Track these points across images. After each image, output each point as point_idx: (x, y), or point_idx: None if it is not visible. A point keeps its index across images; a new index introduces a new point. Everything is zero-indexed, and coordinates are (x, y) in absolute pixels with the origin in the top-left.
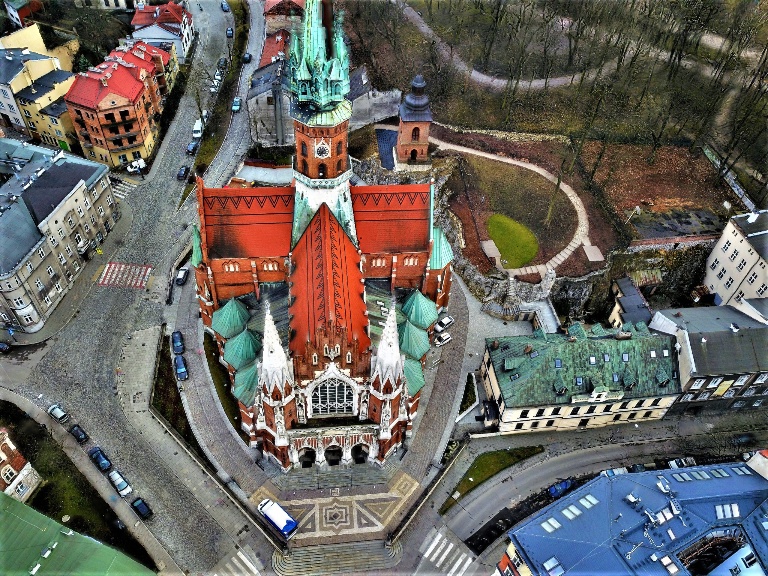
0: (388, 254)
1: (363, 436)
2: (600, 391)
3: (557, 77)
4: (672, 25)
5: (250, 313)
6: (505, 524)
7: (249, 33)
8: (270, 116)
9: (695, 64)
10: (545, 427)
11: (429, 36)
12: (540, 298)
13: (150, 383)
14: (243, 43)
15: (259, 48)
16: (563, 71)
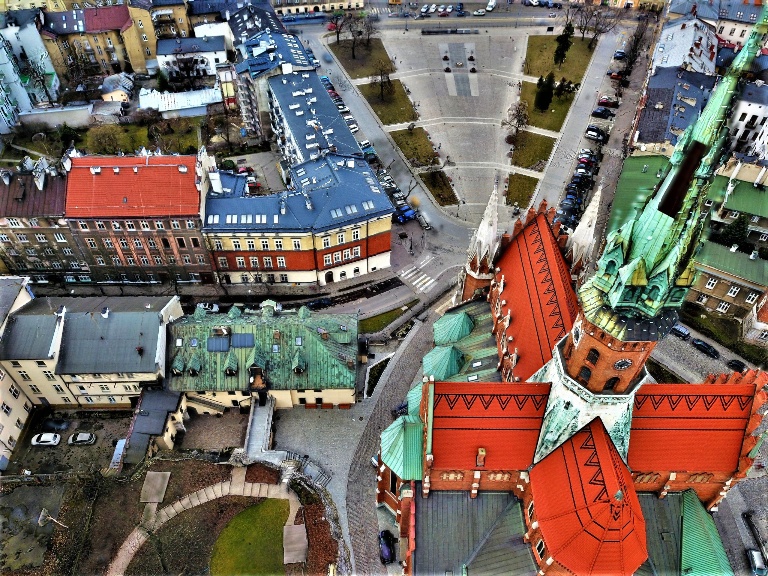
0: None
1: None
2: (272, 301)
3: None
4: None
5: None
6: (372, 288)
7: None
8: None
9: None
10: None
11: None
12: None
13: None
14: None
15: None
16: None
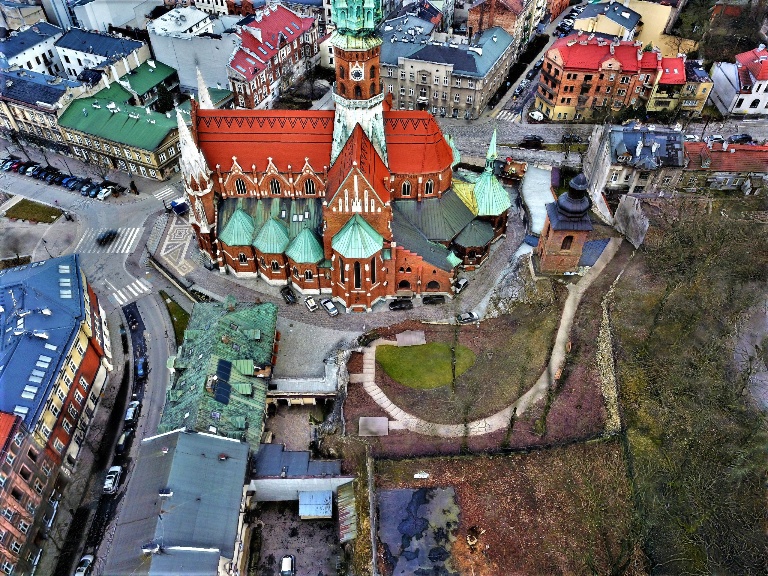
0: None
1: None
2: None
3: None
4: None
5: None
6: None
7: None
8: None
9: None
10: None
11: None
12: None
13: None
14: None
15: None
16: None
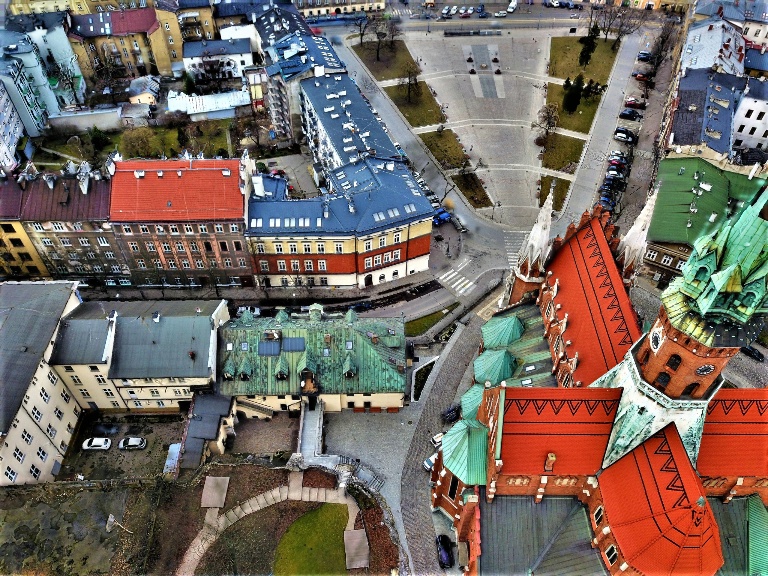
0: None
1: None
2: (319, 305)
3: None
4: None
5: None
6: (411, 291)
7: None
8: None
9: None
10: None
11: None
12: None
13: None
14: None
15: None
16: None
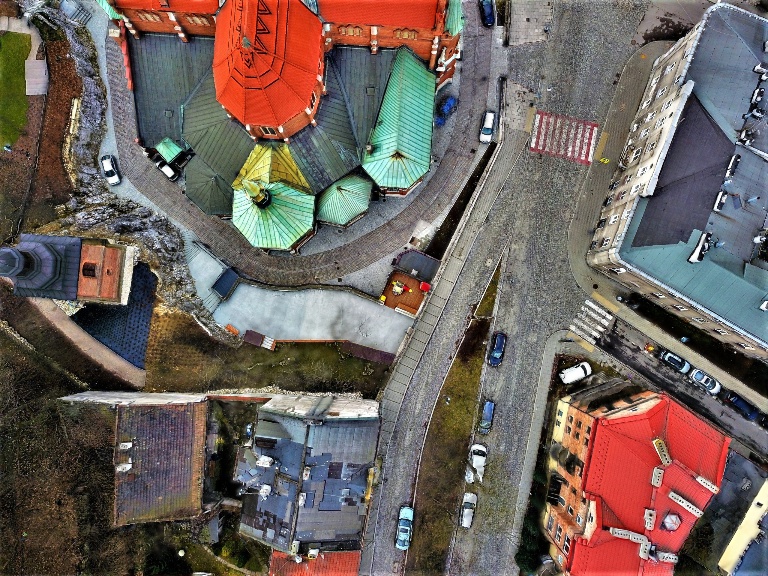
0: None
1: None
2: None
3: None
4: None
5: None
6: None
7: None
8: None
9: None
10: None
11: None
12: None
13: None
14: None
15: None
16: None
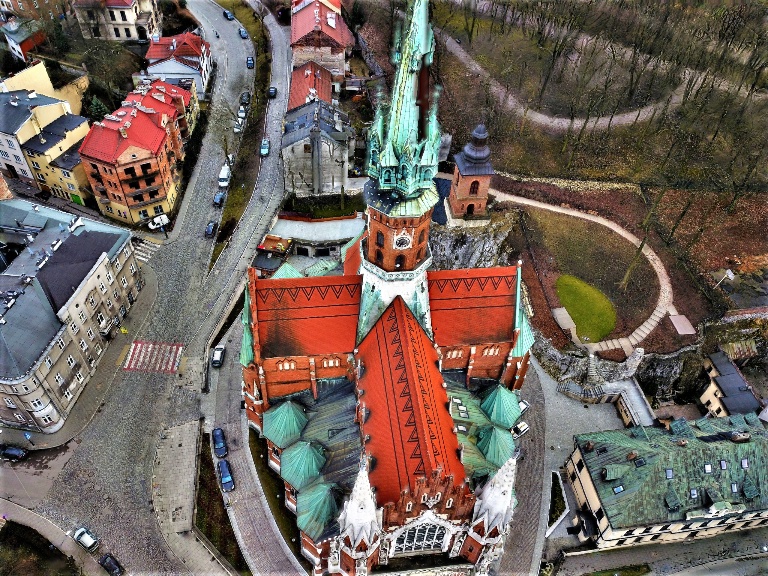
0: (466, 345)
1: (453, 575)
2: (721, 508)
3: (617, 114)
4: (755, 61)
5: (307, 416)
6: None
7: (272, 63)
8: (306, 165)
9: (764, 97)
10: (648, 541)
11: (471, 67)
12: (624, 377)
13: (191, 495)
14: (266, 75)
15: (284, 80)
16: (622, 107)
